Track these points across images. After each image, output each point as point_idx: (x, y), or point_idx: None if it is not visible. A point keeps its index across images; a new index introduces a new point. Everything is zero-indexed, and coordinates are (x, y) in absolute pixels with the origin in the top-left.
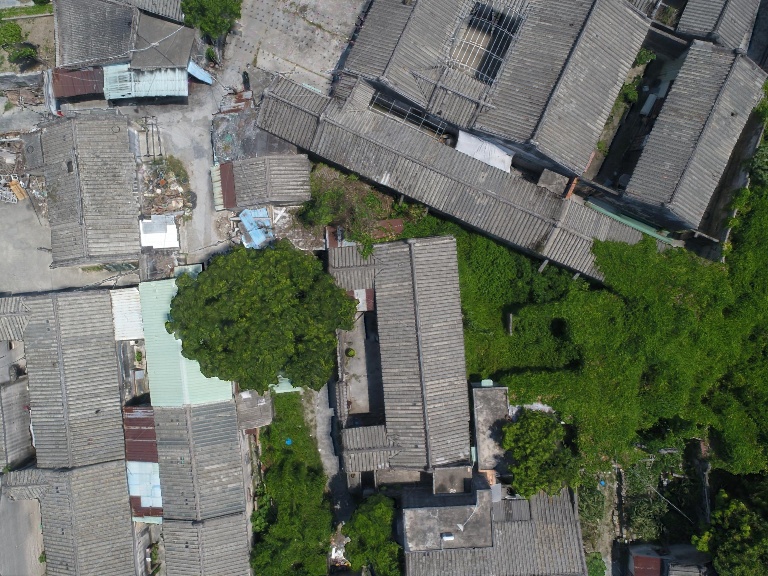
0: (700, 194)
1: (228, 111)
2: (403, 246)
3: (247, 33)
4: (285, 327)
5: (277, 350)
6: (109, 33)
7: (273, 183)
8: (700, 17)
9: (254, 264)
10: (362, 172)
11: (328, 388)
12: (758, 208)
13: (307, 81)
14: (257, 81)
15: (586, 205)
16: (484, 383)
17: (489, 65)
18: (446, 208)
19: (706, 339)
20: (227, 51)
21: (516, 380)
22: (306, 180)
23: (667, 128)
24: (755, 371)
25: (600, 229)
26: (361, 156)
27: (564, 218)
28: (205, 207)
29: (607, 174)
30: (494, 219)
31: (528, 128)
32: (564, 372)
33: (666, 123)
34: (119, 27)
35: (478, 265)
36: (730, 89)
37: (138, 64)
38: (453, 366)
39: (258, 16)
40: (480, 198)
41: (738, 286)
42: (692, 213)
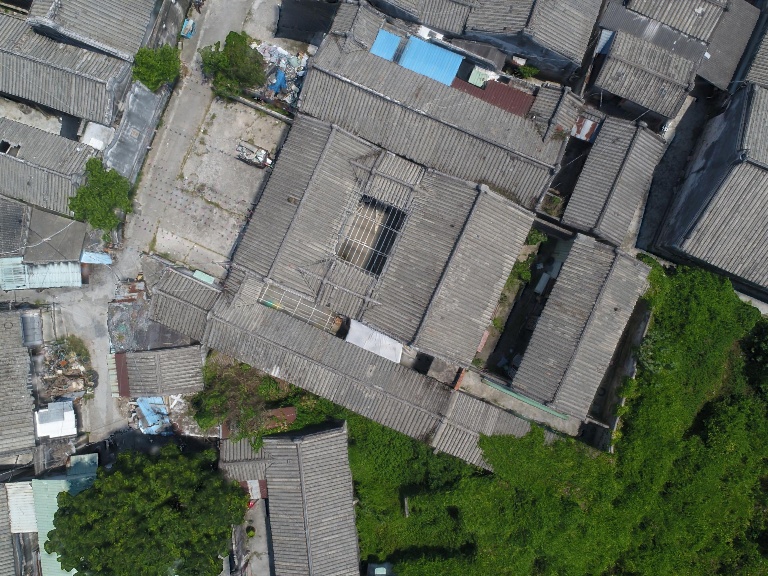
0: (585, 388)
1: (122, 300)
2: (291, 443)
3: (146, 212)
4: (167, 539)
5: (159, 562)
6: (1, 229)
7: (164, 378)
8: (583, 210)
9: (132, 482)
10: (253, 364)
11: (230, 565)
12: (646, 396)
13: (206, 259)
14: (150, 271)
15: (483, 382)
16: (377, 571)
17: (374, 262)
18: (336, 400)
19: (593, 533)
20: (127, 230)
21: (409, 568)
22: (198, 371)
23: (551, 323)
24: (645, 560)
25: (487, 422)
26: (250, 350)
27: (451, 412)
28: (107, 385)
29: (503, 351)
30: (383, 411)
31: (410, 329)
32: (458, 558)
33: (551, 317)
34: (11, 223)
35: (374, 446)
36: (612, 286)
37: (31, 258)
38: (344, 558)
39: (157, 195)
40: (368, 392)
41: (627, 475)
42: (578, 407)
